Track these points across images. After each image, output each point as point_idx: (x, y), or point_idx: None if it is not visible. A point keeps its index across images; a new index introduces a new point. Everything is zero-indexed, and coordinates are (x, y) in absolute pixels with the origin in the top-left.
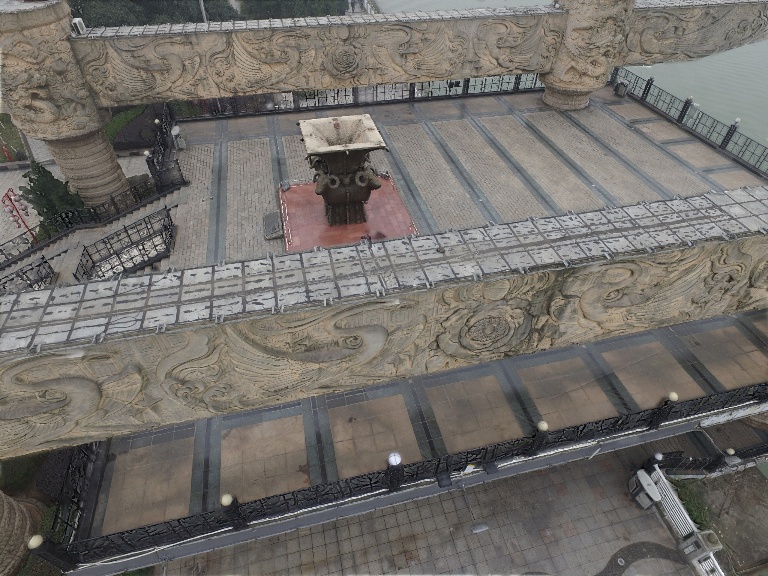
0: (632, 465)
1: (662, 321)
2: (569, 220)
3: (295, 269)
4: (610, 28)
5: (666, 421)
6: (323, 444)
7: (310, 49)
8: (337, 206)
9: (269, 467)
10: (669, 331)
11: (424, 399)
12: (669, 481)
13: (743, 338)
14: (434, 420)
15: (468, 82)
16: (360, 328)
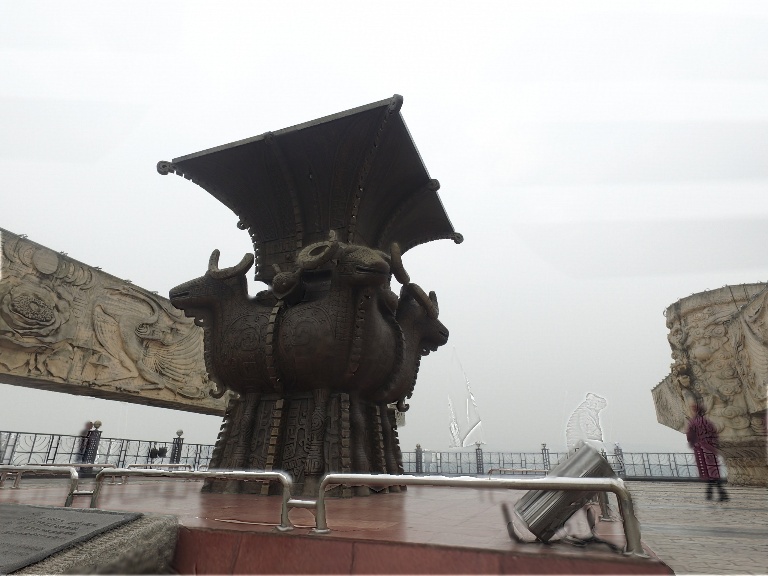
0: None
1: None
2: None
3: None
4: None
5: None
6: None
7: None
8: (356, 400)
9: None
10: None
11: None
12: None
13: None
14: None
15: (179, 451)
16: None
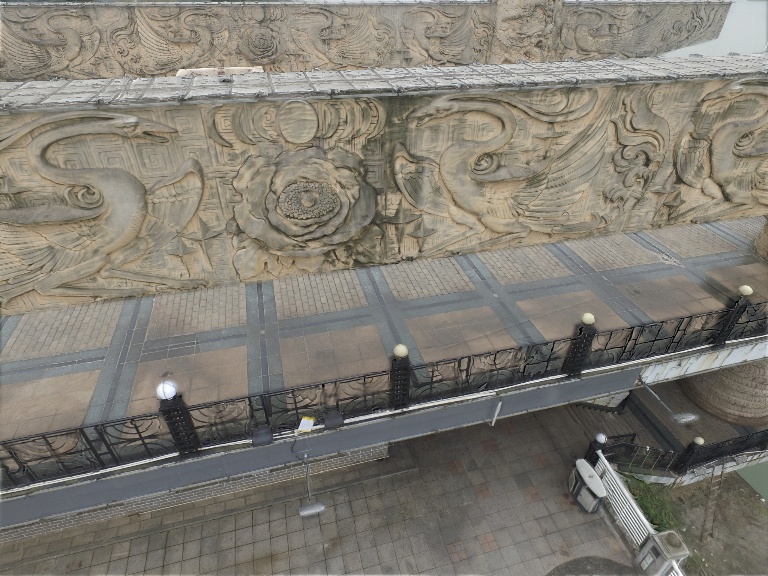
0: (574, 460)
1: (570, 226)
2: (422, 69)
3: (1, 89)
4: (540, 18)
5: (590, 366)
6: (114, 403)
7: (223, 30)
8: None
9: (22, 431)
10: (602, 280)
11: (274, 351)
12: (617, 472)
13: (693, 286)
14: (280, 373)
15: None
16: (91, 170)
